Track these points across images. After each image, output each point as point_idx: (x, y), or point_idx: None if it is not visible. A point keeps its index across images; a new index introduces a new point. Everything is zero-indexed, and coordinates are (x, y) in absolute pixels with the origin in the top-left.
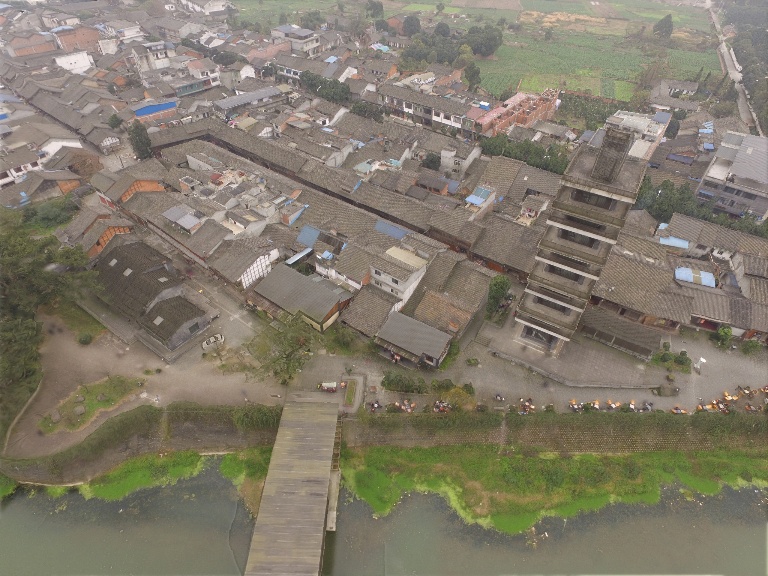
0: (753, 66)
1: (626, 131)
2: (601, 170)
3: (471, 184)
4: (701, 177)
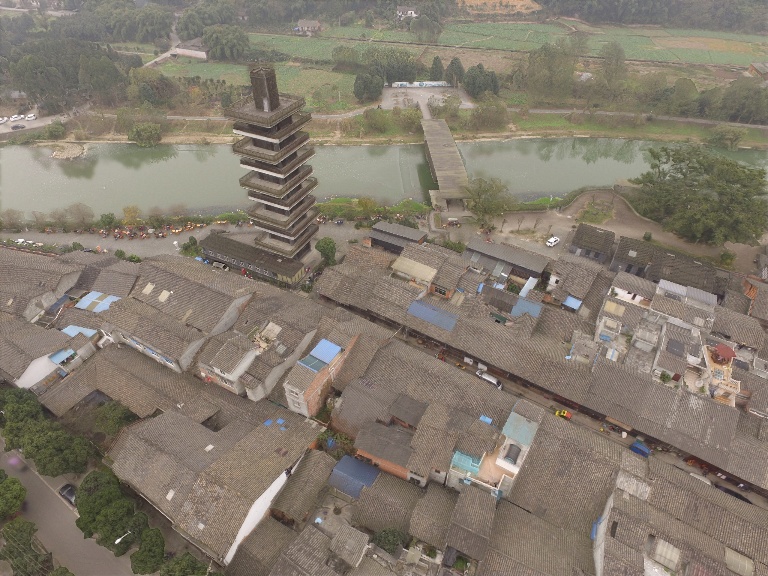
0: None
1: None
2: None
3: (311, 467)
4: None
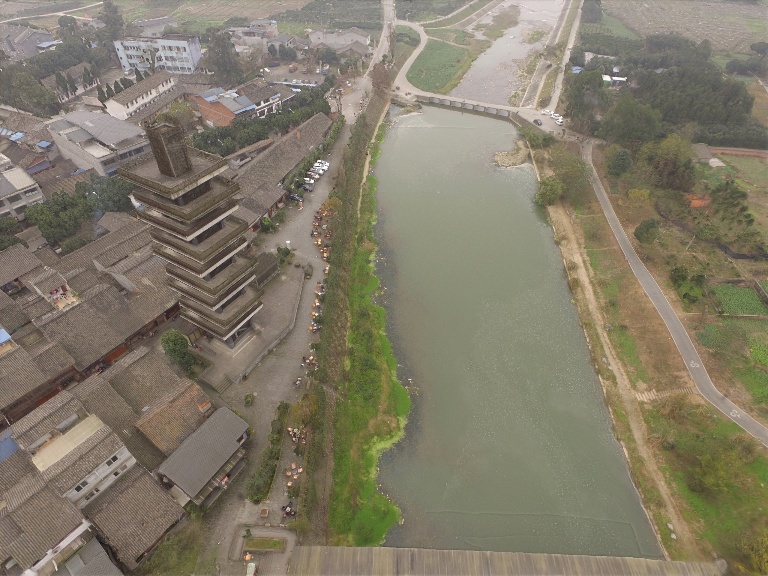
0: None
1: None
2: (179, 166)
3: None
4: (77, 168)
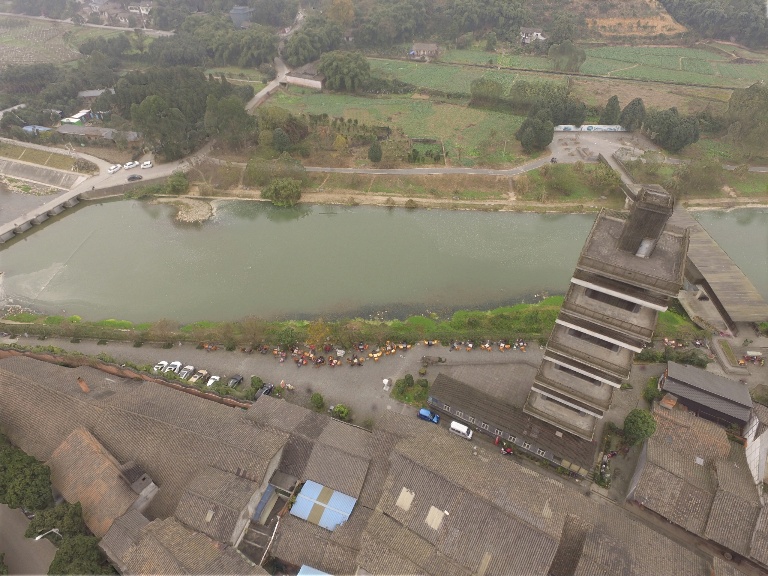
0: None
1: (650, 203)
2: None
3: None
4: None
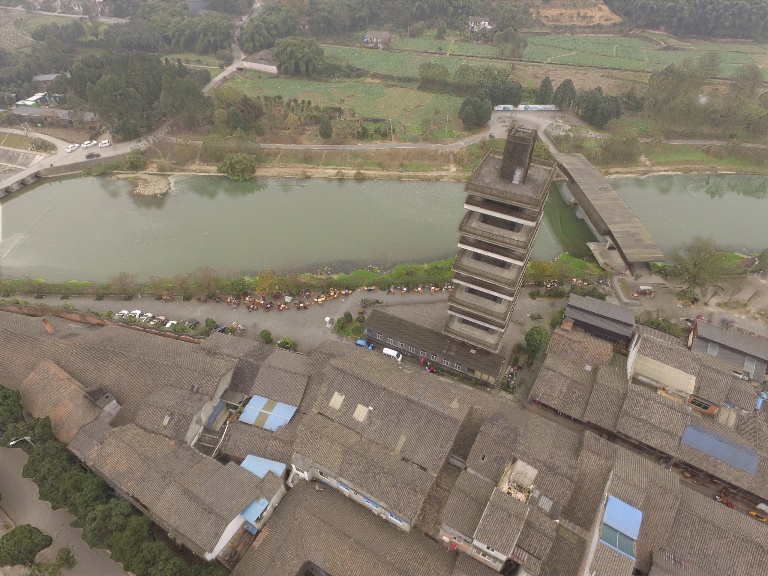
0: None
1: (517, 136)
2: None
3: None
4: None
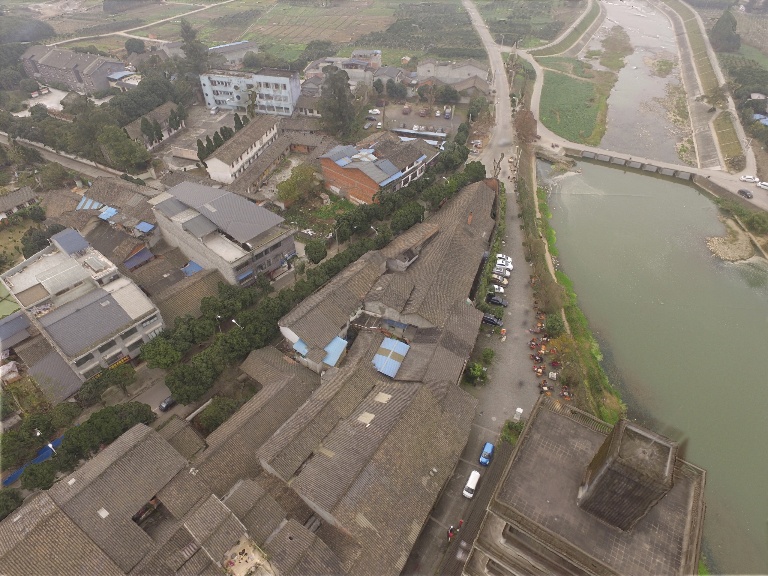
0: (1, 115)
1: None
2: None
3: None
4: (188, 260)
